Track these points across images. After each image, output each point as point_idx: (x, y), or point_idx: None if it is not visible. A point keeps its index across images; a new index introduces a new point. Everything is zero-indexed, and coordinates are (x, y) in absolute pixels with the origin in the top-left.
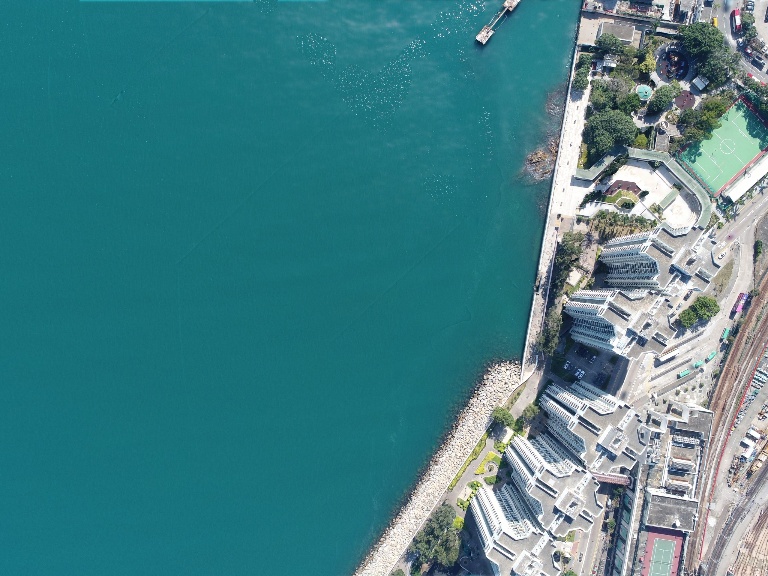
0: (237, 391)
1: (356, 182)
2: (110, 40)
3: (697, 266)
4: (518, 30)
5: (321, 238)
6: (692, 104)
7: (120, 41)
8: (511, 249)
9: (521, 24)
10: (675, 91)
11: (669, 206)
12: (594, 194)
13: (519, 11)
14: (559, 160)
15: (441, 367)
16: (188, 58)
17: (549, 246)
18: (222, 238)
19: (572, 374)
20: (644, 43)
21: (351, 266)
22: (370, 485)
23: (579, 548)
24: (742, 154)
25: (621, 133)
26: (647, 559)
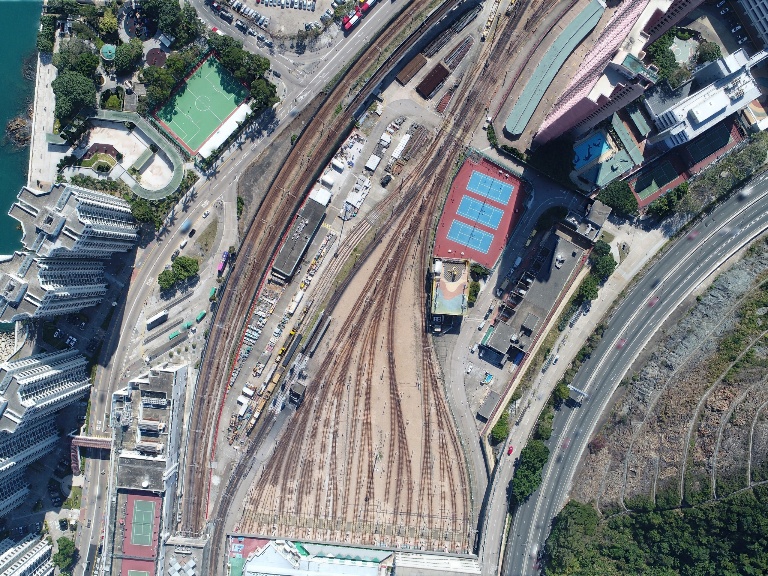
0: None
1: None
2: None
3: (55, 224)
4: None
5: None
6: (164, 62)
7: None
8: None
9: None
10: (133, 49)
11: (148, 167)
12: (66, 159)
13: None
14: (35, 126)
15: None
16: None
17: None
18: None
19: (64, 342)
20: (109, 1)
21: None
22: None
23: (87, 515)
24: (218, 110)
25: (73, 95)
26: (128, 521)
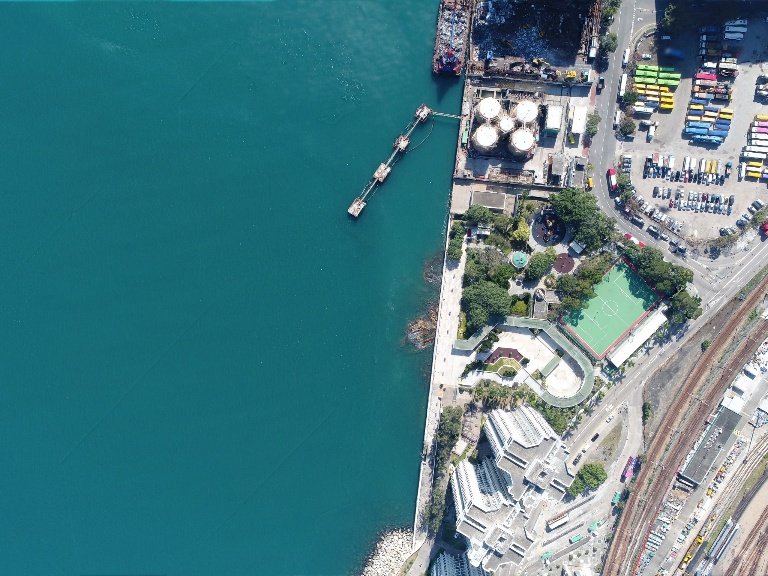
0: (133, 574)
1: (229, 374)
2: None
3: (549, 479)
4: (391, 199)
5: (198, 431)
6: (571, 267)
7: None
8: (396, 419)
9: (393, 194)
10: (549, 259)
11: (553, 371)
12: (474, 365)
13: (391, 179)
14: (439, 330)
15: (336, 535)
16: (55, 264)
17: (433, 416)
18: (102, 436)
19: (463, 542)
20: (518, 208)
21: (230, 456)
22: None
23: None
24: (626, 315)
25: (494, 308)
26: None
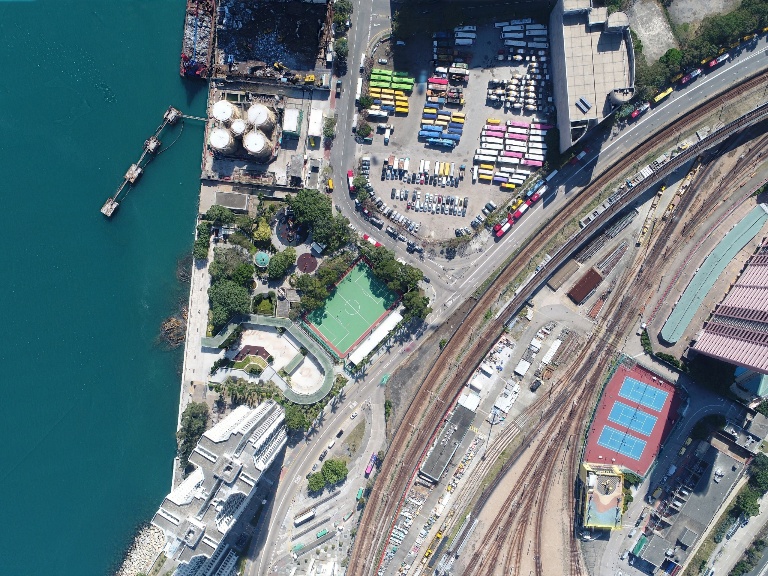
0: None
1: None
2: None
3: (234, 473)
4: (143, 200)
5: None
6: (314, 266)
7: None
8: (152, 415)
9: (144, 194)
10: (287, 259)
11: (298, 369)
12: (220, 362)
13: (144, 180)
14: (189, 327)
15: (97, 529)
16: None
17: None
18: None
19: None
20: None
21: None
22: None
23: None
24: (367, 314)
25: (231, 306)
26: None
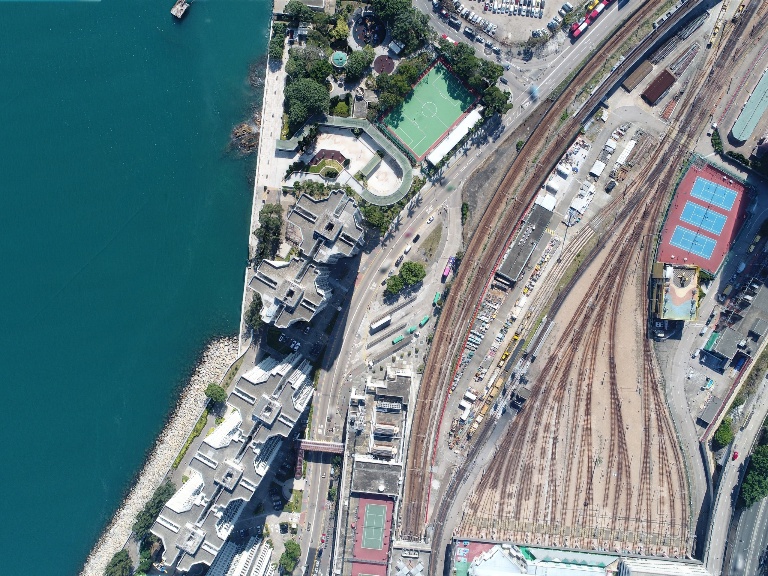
0: None
1: (40, 164)
2: None
3: (336, 230)
4: (214, 2)
5: (8, 223)
6: (391, 69)
7: None
8: (222, 224)
9: None
10: (367, 56)
11: (374, 173)
12: (296, 165)
13: None
14: (262, 132)
15: (163, 346)
16: None
17: (258, 219)
18: None
19: (288, 346)
20: (339, 9)
21: (41, 250)
22: (98, 468)
23: (307, 518)
24: (444, 117)
25: (310, 101)
26: (359, 525)
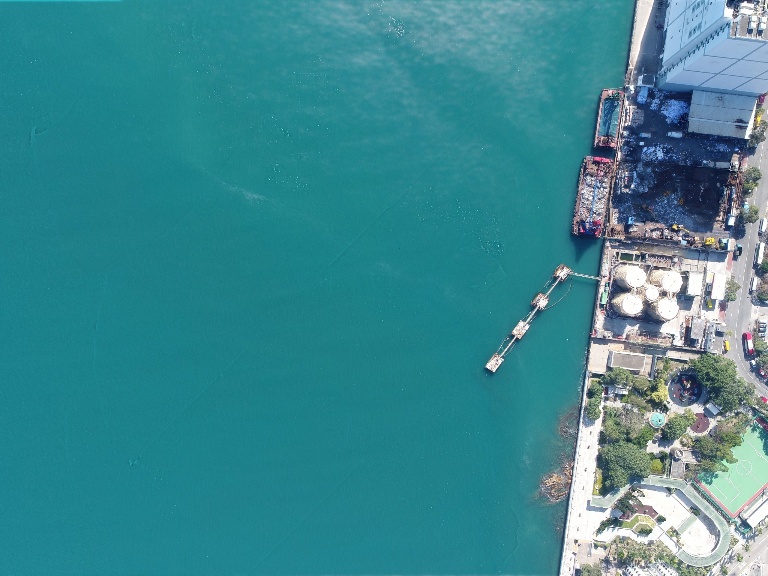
0: None
1: (373, 535)
2: (125, 408)
3: None
4: (528, 355)
5: None
6: (706, 426)
7: (134, 409)
8: (529, 572)
9: (530, 350)
10: (689, 422)
11: None
12: (611, 522)
13: (528, 335)
14: (574, 485)
15: None
16: (202, 424)
17: (567, 570)
18: None
19: None
20: (655, 368)
21: None
22: None
23: None
24: (759, 475)
25: (636, 471)
26: None
